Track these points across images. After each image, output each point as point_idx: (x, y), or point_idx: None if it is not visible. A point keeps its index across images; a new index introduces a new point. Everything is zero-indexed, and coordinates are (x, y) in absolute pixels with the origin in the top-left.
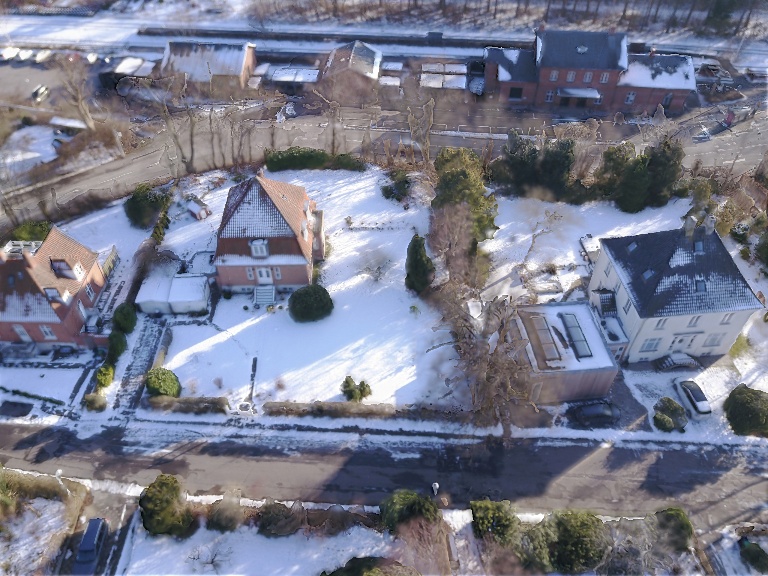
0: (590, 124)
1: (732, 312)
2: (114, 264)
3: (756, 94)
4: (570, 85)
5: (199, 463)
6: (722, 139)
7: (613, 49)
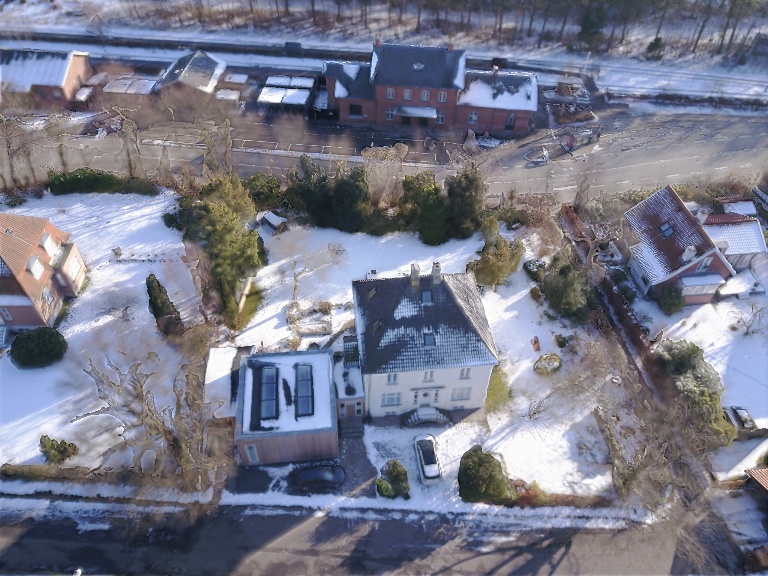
0: (397, 149)
1: (466, 367)
2: None
3: (609, 115)
4: (408, 103)
5: None
6: (560, 164)
7: (450, 67)
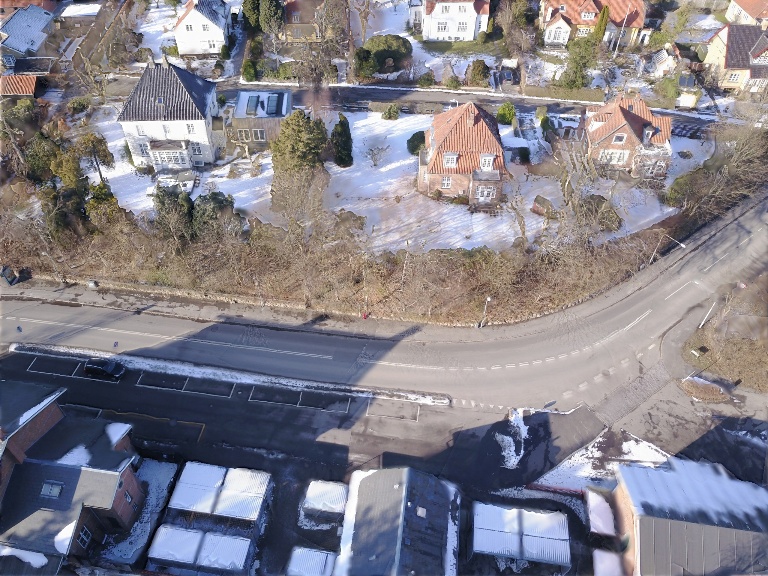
0: (105, 237)
1: None
2: None
3: None
4: None
5: None
6: None
7: None
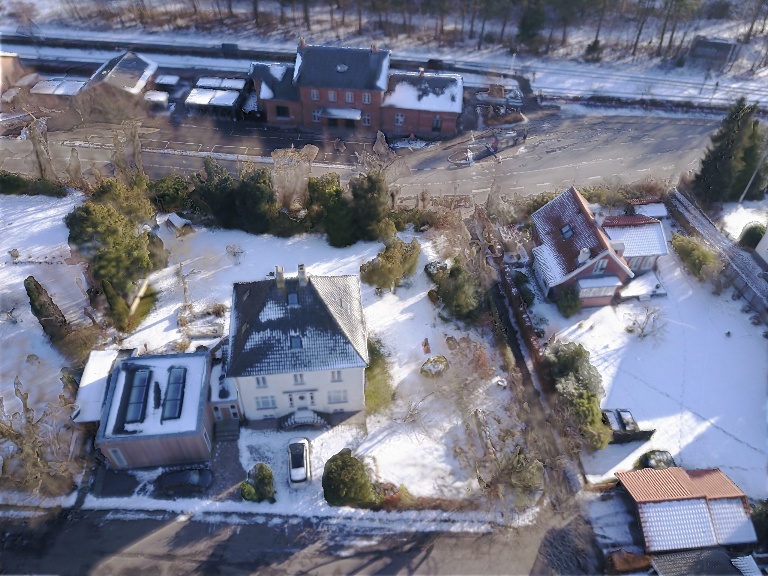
0: (306, 151)
1: (335, 370)
2: None
3: (539, 117)
4: (333, 105)
5: None
6: (482, 165)
7: (374, 68)
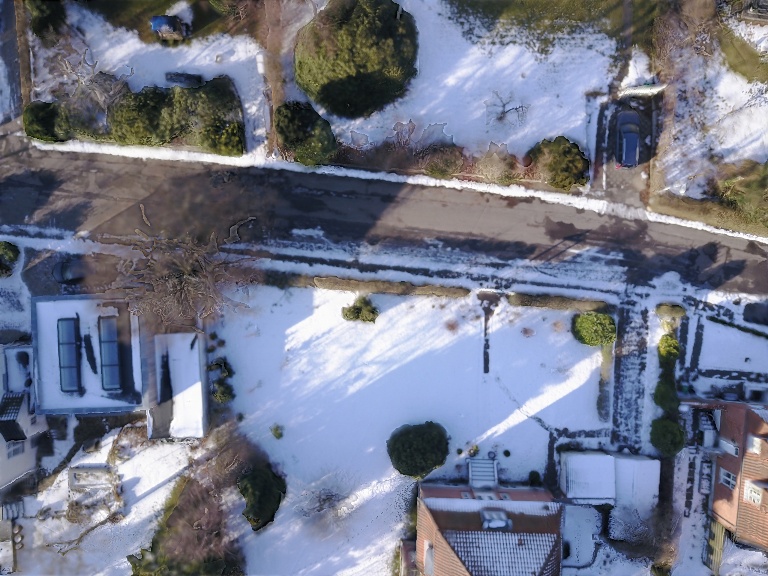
0: None
1: None
2: (709, 549)
3: None
4: None
5: (535, 234)
6: None
7: None
